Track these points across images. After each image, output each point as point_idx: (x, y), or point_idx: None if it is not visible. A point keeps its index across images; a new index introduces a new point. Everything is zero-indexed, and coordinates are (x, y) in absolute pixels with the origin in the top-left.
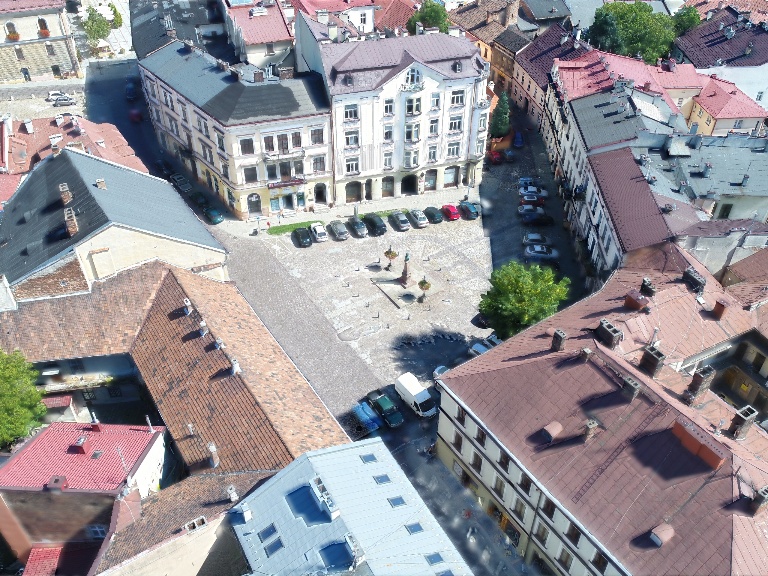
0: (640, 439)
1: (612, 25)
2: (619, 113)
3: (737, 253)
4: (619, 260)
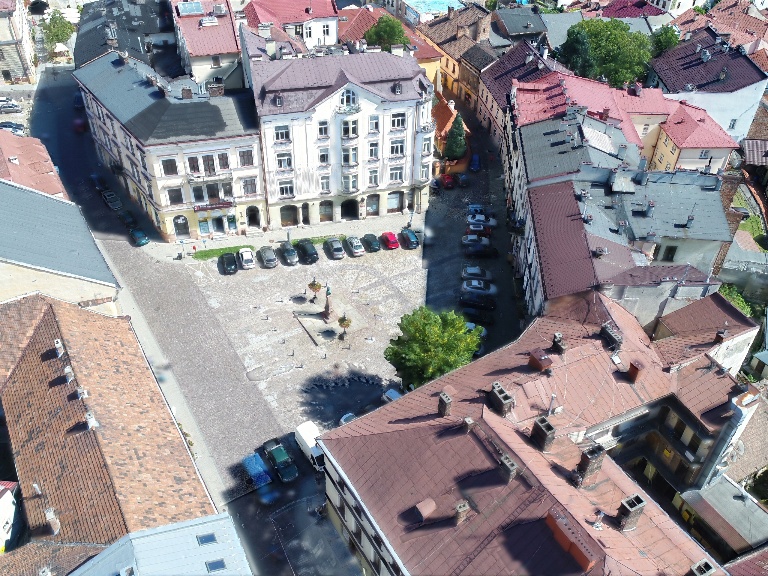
0: (512, 527)
1: (584, 44)
2: (566, 143)
3: (669, 304)
4: (542, 307)
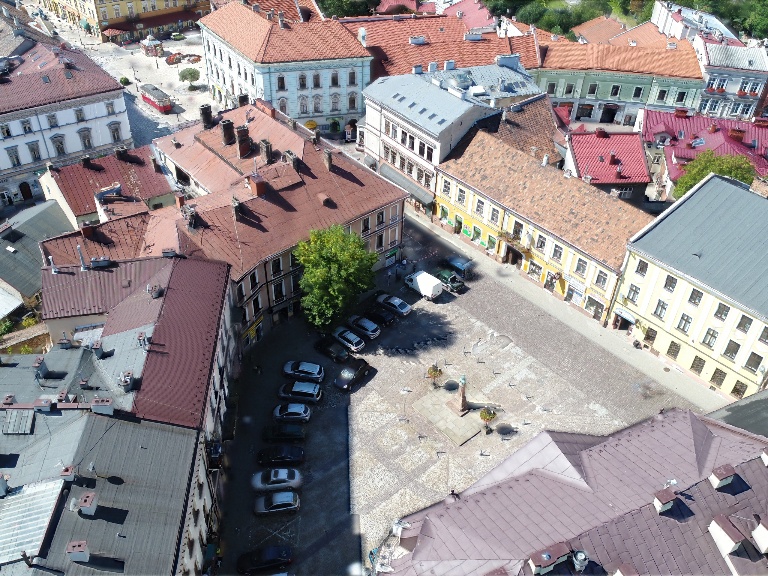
0: None
1: None
2: (98, 504)
3: None
4: None
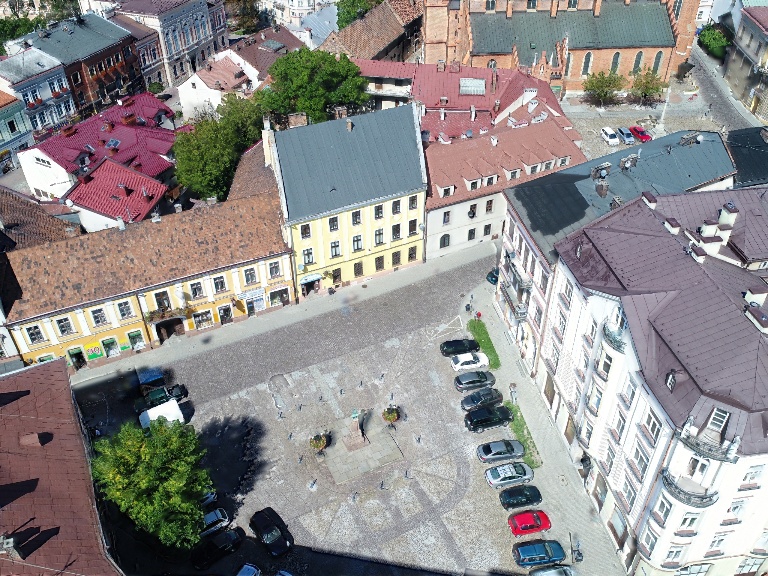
0: None
1: None
2: None
3: None
4: None
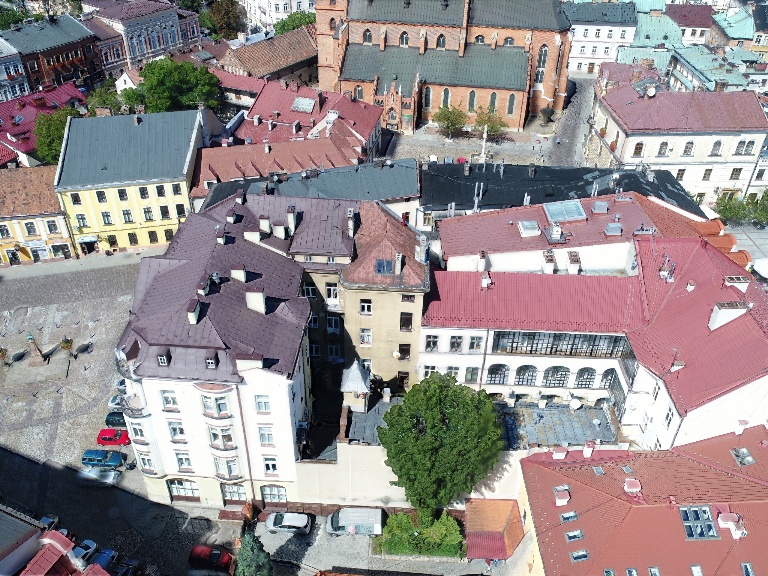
0: None
1: None
2: None
3: None
4: None
